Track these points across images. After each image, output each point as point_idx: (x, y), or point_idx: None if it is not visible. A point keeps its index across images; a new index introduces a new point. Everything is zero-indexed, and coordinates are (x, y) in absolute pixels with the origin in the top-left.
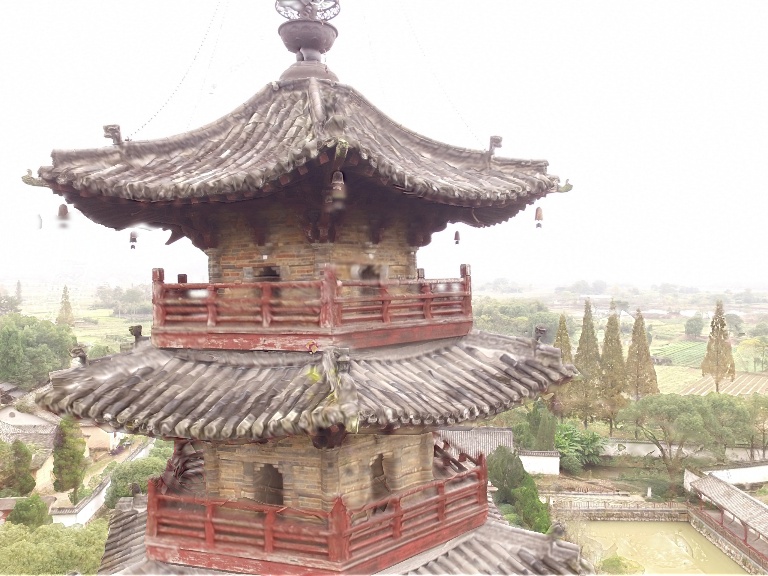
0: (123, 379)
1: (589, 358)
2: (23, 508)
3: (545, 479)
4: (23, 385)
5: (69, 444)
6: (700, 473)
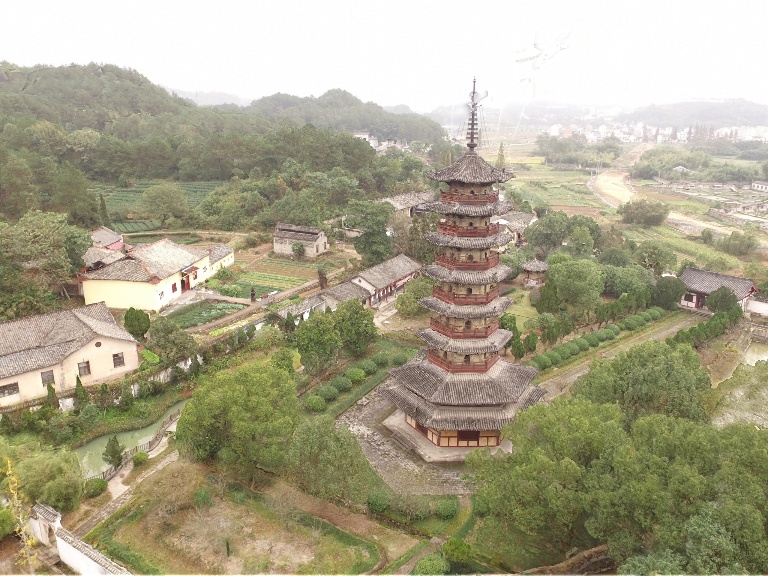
0: (435, 205)
1: None
2: None
3: None
4: None
5: None
6: None
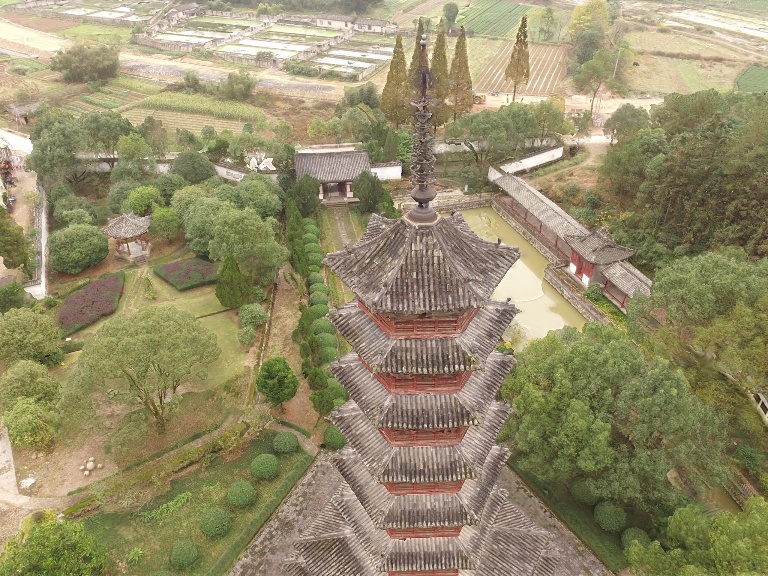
0: (390, 354)
1: None
2: (10, 294)
3: (391, 183)
4: None
5: (10, 233)
6: (500, 170)
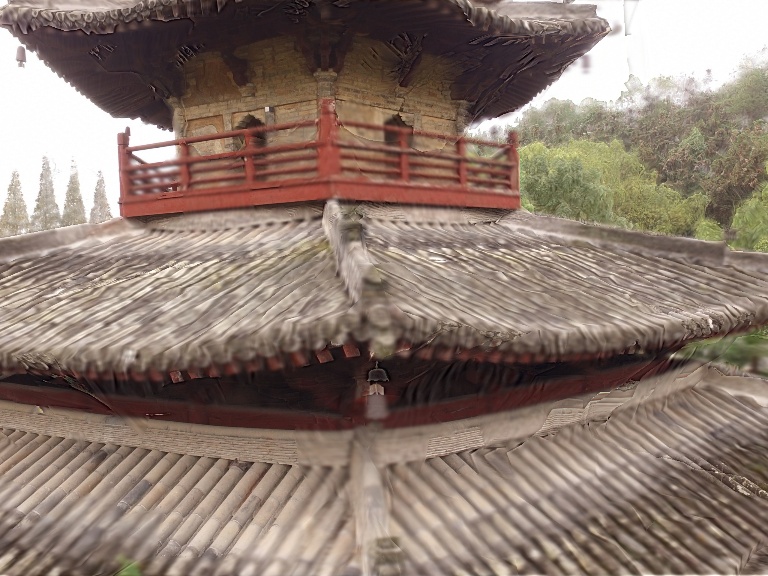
0: None
1: (49, 217)
2: None
3: None
4: None
5: None
6: None
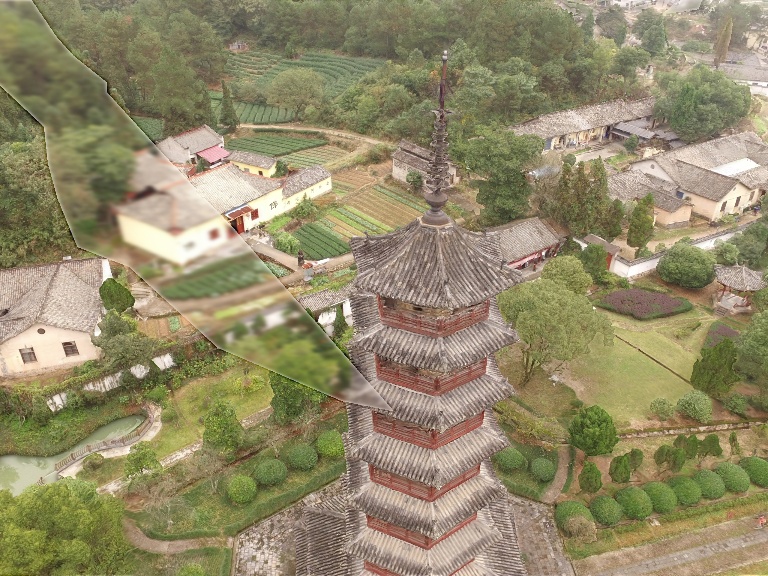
0: None
1: None
2: (590, 250)
3: None
4: (684, 137)
5: (640, 217)
6: None
